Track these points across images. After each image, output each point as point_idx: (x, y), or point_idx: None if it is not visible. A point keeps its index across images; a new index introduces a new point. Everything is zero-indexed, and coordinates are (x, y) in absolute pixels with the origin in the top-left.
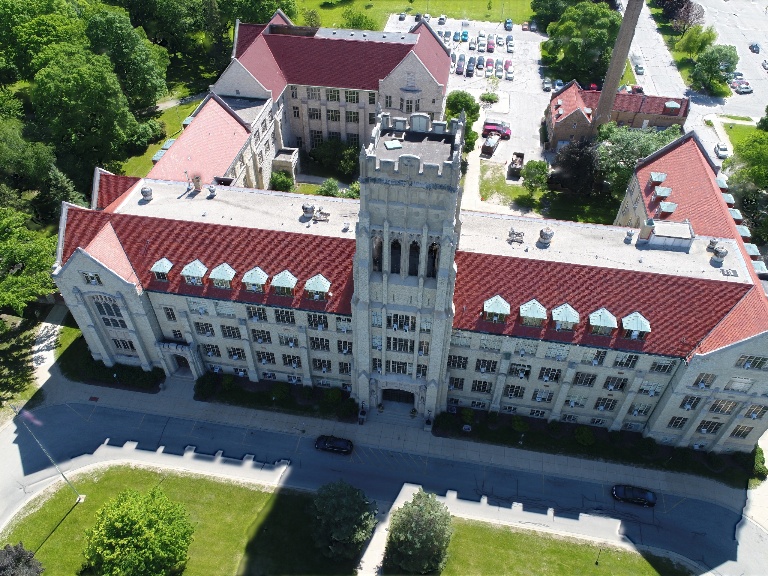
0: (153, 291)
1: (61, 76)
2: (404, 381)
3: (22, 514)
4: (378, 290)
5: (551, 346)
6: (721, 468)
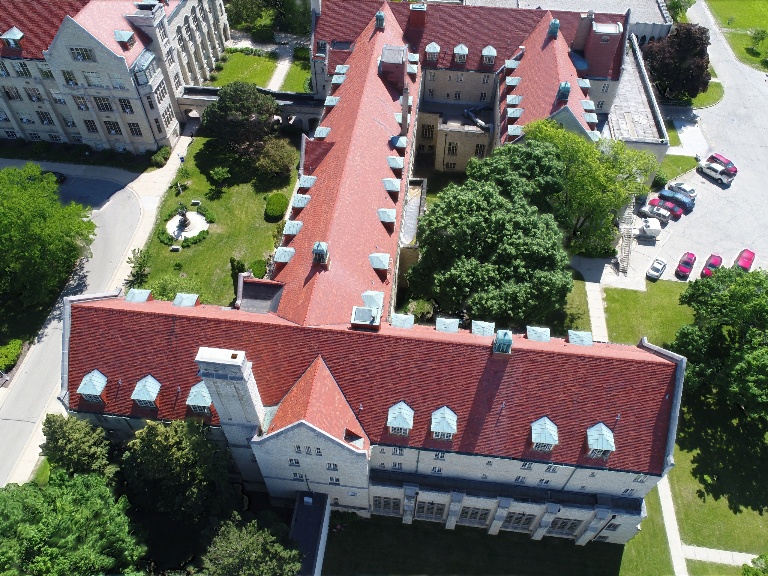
0: None
1: None
2: None
3: None
4: None
5: None
6: (131, 161)
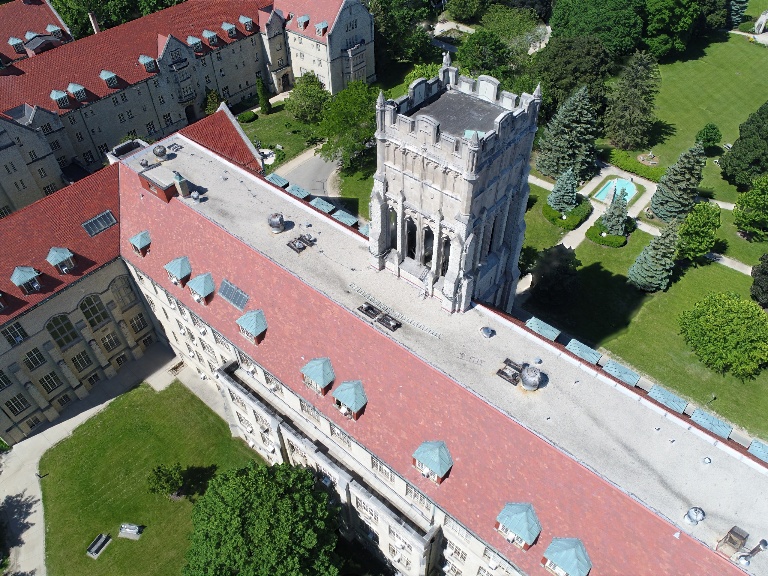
0: None
1: None
2: None
3: None
4: None
5: None
6: None
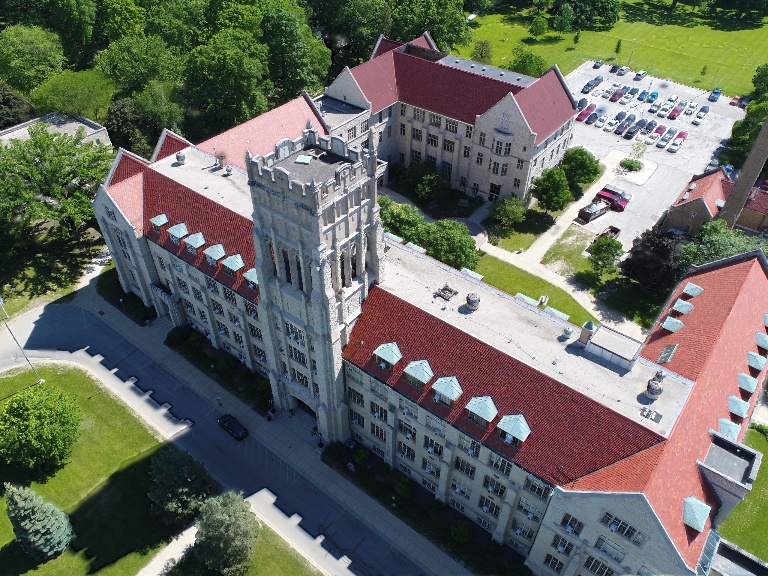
0: (149, 238)
1: (211, 54)
2: (304, 394)
3: (2, 375)
4: (276, 294)
5: (430, 415)
6: None
